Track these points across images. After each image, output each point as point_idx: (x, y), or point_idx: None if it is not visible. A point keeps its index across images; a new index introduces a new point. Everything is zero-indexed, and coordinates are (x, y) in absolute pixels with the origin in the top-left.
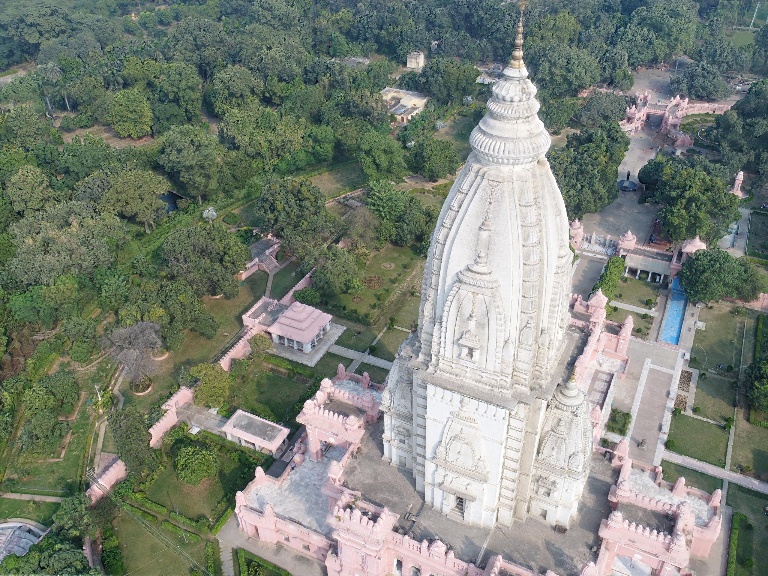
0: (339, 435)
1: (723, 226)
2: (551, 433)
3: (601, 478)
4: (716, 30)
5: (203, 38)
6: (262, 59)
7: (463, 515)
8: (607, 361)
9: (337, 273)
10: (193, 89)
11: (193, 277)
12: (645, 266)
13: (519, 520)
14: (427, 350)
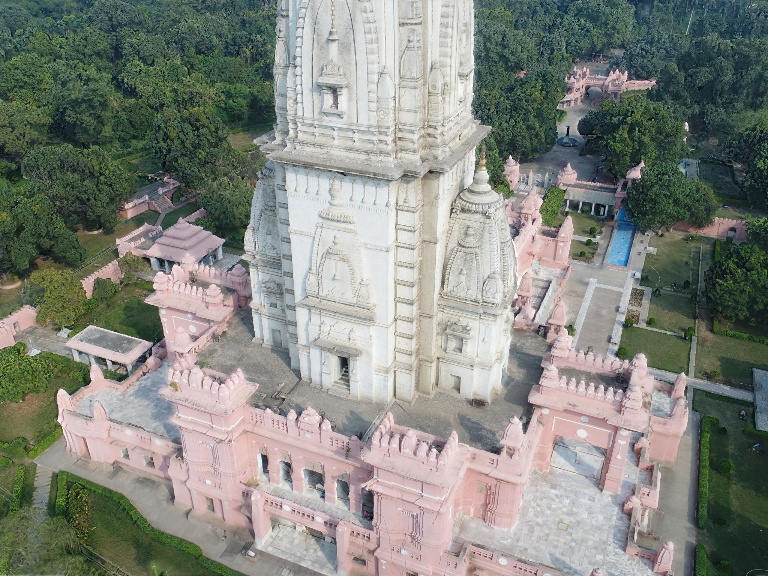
0: (197, 313)
1: (670, 154)
2: (457, 248)
3: (533, 353)
4: (653, 28)
5: (119, 17)
6: (179, 30)
7: (349, 388)
8: (545, 270)
9: (236, 203)
10: (101, 56)
11: (56, 192)
12: (587, 198)
13: (425, 395)
14: (285, 126)
